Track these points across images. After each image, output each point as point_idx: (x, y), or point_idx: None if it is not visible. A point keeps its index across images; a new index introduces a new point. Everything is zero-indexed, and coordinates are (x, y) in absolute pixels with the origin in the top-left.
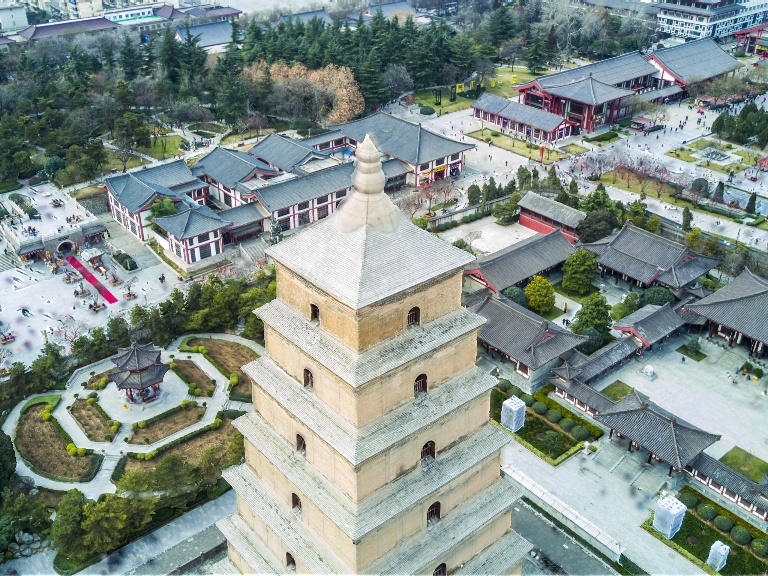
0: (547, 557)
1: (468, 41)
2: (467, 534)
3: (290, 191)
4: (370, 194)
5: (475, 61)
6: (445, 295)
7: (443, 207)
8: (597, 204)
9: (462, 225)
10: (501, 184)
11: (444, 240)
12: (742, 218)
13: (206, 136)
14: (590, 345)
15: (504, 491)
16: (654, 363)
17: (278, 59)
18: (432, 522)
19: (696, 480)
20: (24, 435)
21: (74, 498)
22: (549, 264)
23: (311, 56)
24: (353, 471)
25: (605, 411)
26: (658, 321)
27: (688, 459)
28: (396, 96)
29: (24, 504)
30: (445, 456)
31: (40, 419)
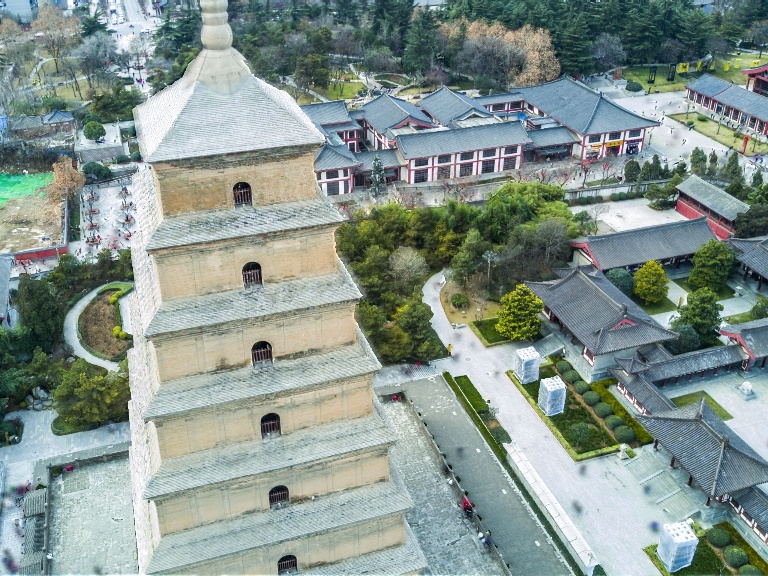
0: (491, 542)
1: (704, 17)
2: (309, 460)
3: (433, 142)
4: (209, 49)
5: (706, 39)
6: (288, 178)
7: (601, 183)
8: (767, 197)
9: (608, 202)
10: (668, 165)
11: (571, 211)
12: None
13: (387, 86)
14: (681, 345)
15: (374, 429)
16: (760, 382)
17: (481, 17)
18: (271, 436)
19: (741, 518)
20: (90, 312)
21: (79, 366)
22: (677, 253)
23: (514, 16)
24: None
25: (654, 414)
26: None
27: (729, 488)
28: (604, 69)
29: (43, 363)
30: (286, 364)
31: (108, 301)
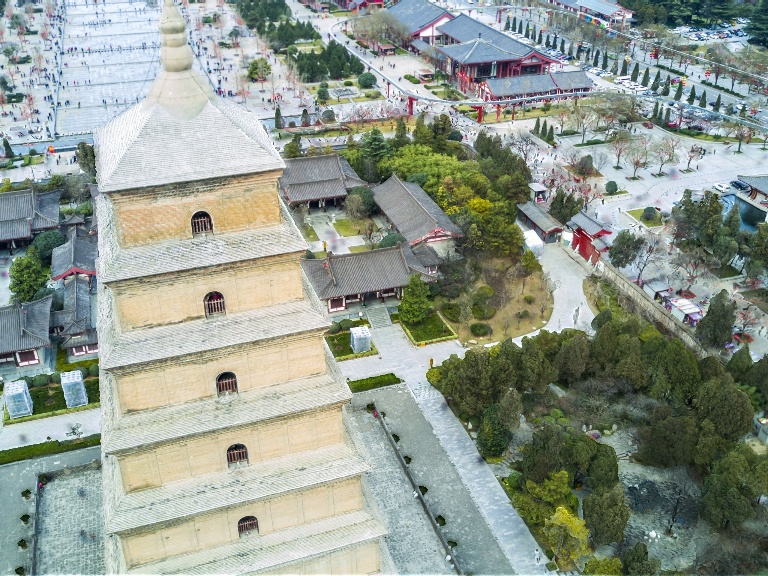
0: None
1: None
2: None
3: None
4: (189, 69)
5: None
6: None
7: None
8: None
9: None
10: None
11: None
12: (12, 164)
13: None
14: (54, 303)
15: None
16: None
17: None
18: None
19: None
20: None
21: None
22: None
23: None
24: (320, 341)
25: None
26: (82, 253)
27: None
28: None
29: None
30: None
31: None
